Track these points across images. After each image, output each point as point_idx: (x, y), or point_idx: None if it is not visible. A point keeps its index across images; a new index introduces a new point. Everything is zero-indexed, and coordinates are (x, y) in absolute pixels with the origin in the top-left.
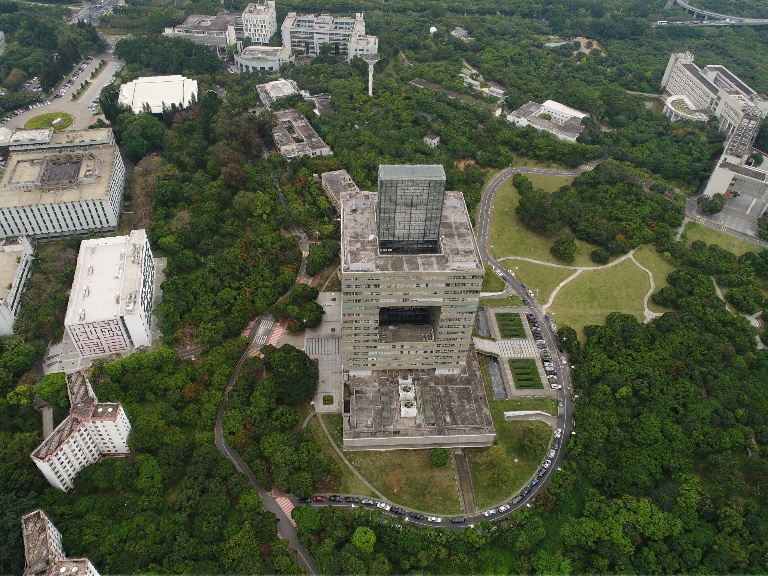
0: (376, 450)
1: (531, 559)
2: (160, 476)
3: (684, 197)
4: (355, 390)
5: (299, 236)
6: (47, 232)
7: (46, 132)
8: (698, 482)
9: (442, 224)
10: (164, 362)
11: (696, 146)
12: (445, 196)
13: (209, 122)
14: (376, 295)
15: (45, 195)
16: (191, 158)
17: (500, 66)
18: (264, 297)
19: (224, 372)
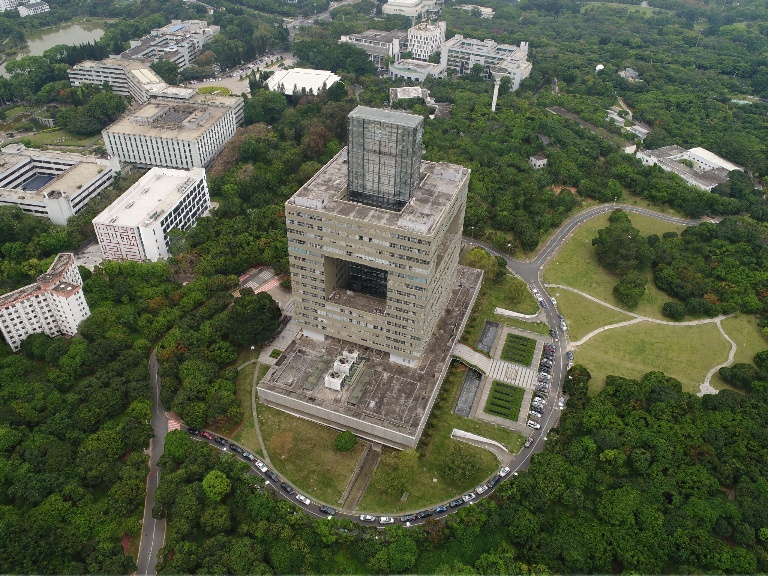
0: (290, 413)
1: None
2: (80, 359)
3: None
4: (299, 349)
5: None
6: (145, 163)
7: (190, 91)
8: None
9: (424, 190)
10: None
11: None
12: (445, 167)
13: None
14: (319, 239)
15: (152, 130)
16: (294, 132)
17: (658, 109)
18: (274, 249)
19: (195, 298)
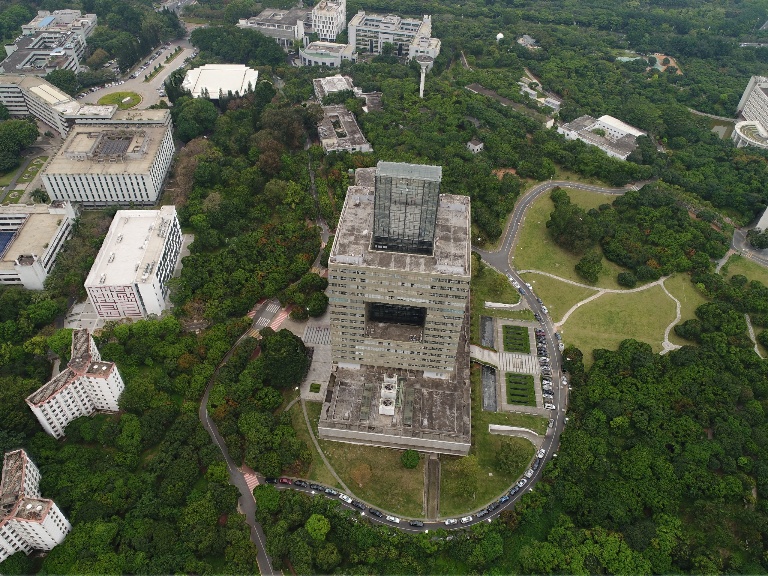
0: (351, 443)
1: (482, 575)
2: (139, 436)
3: (732, 227)
4: (340, 381)
5: (321, 227)
6: (93, 200)
7: (110, 108)
8: (679, 526)
9: (441, 227)
10: (169, 332)
11: (758, 175)
12: (450, 199)
13: (261, 111)
14: (362, 289)
15: (95, 166)
16: (237, 144)
17: (562, 77)
18: (274, 282)
19: (220, 348)
